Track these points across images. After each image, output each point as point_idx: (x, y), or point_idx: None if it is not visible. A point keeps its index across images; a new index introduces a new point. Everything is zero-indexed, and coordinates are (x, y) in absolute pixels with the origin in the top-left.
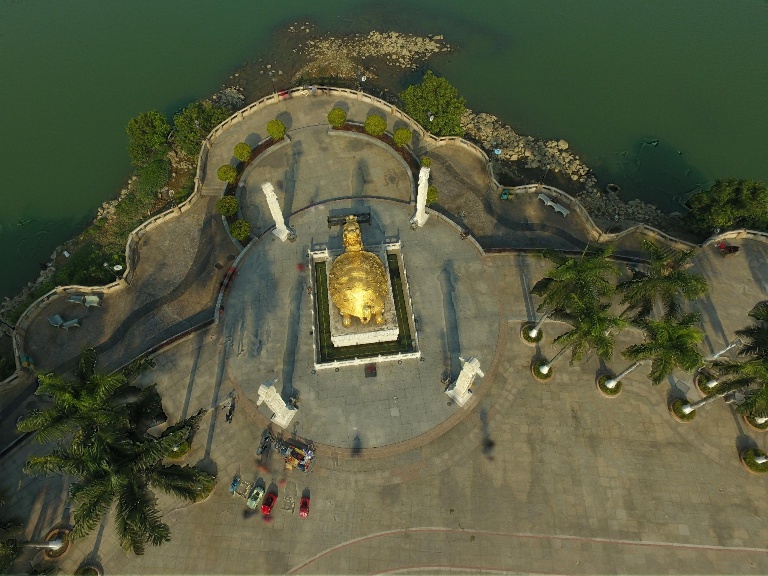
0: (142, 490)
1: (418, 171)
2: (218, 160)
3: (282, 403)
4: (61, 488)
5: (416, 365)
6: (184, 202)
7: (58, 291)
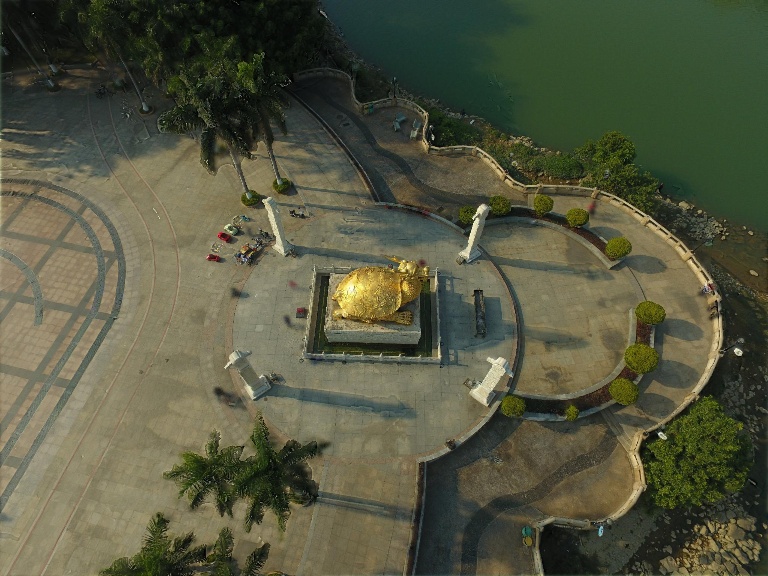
0: (193, 114)
1: (565, 407)
2: (575, 205)
3: (278, 233)
4: (276, 134)
5: (297, 354)
6: (512, 179)
7: (424, 114)
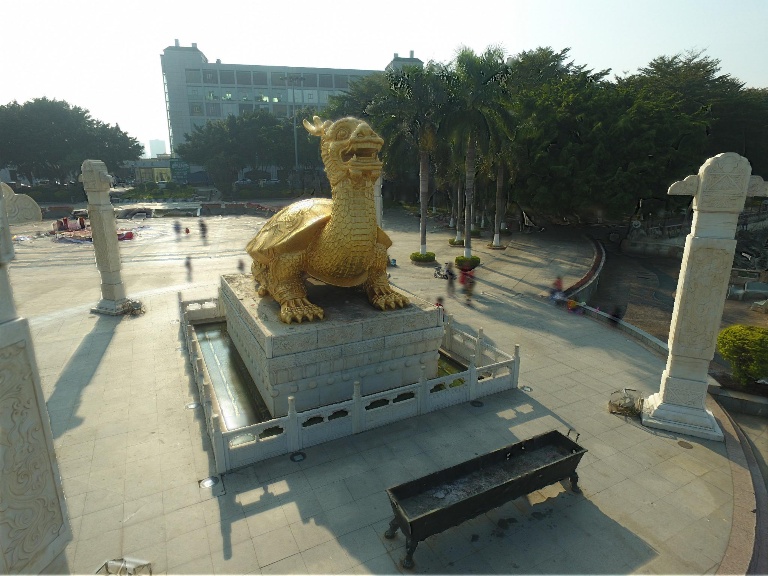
0: None
1: None
2: None
3: None
4: None
5: None
6: None
7: None
